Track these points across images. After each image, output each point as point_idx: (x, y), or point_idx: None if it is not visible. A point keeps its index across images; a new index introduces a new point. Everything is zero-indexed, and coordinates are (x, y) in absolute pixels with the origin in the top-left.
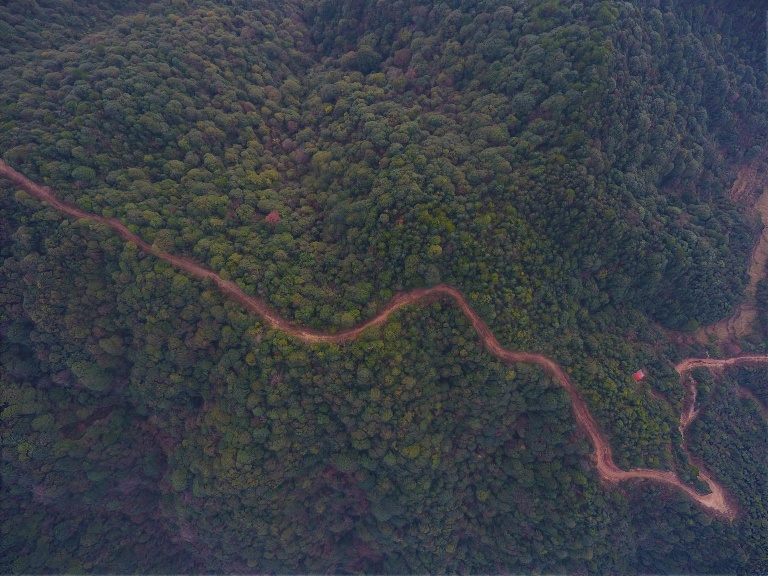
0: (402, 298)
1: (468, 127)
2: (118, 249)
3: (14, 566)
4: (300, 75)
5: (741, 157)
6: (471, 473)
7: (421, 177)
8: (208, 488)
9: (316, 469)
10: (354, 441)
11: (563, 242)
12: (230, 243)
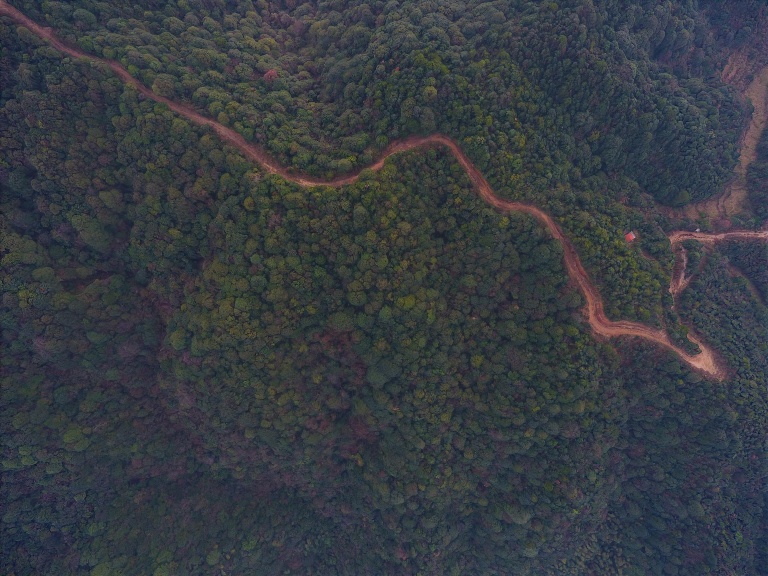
0: (398, 147)
1: None
2: (118, 91)
3: (14, 419)
4: None
5: (732, 39)
6: (465, 340)
7: (417, 27)
8: (206, 341)
9: (313, 331)
10: (350, 294)
11: (556, 97)
12: (229, 93)
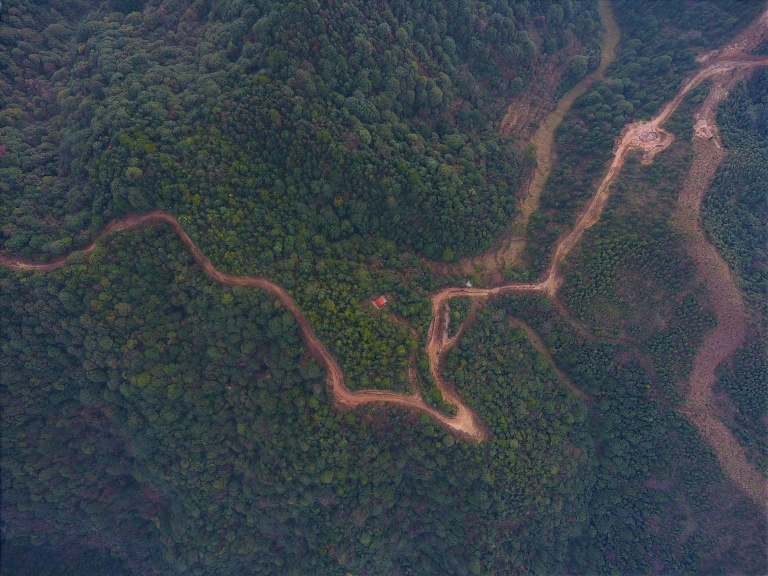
0: (117, 225)
1: (198, 57)
2: None
3: None
4: (76, 21)
5: (505, 89)
6: (231, 407)
7: (131, 103)
8: None
9: (66, 406)
10: None
11: (286, 167)
12: None
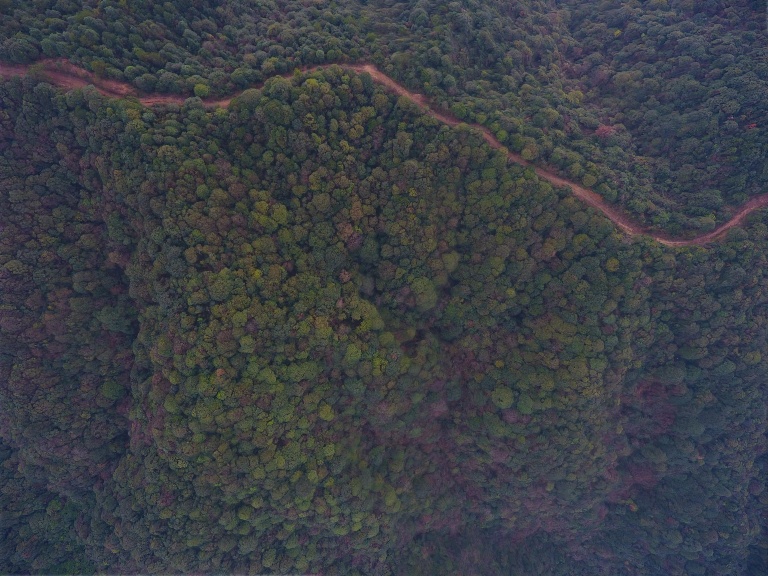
0: (751, 203)
1: None
2: (486, 156)
3: (352, 487)
4: (556, 8)
5: None
6: None
7: None
8: (549, 401)
9: (635, 384)
10: (693, 349)
11: None
12: (578, 153)
